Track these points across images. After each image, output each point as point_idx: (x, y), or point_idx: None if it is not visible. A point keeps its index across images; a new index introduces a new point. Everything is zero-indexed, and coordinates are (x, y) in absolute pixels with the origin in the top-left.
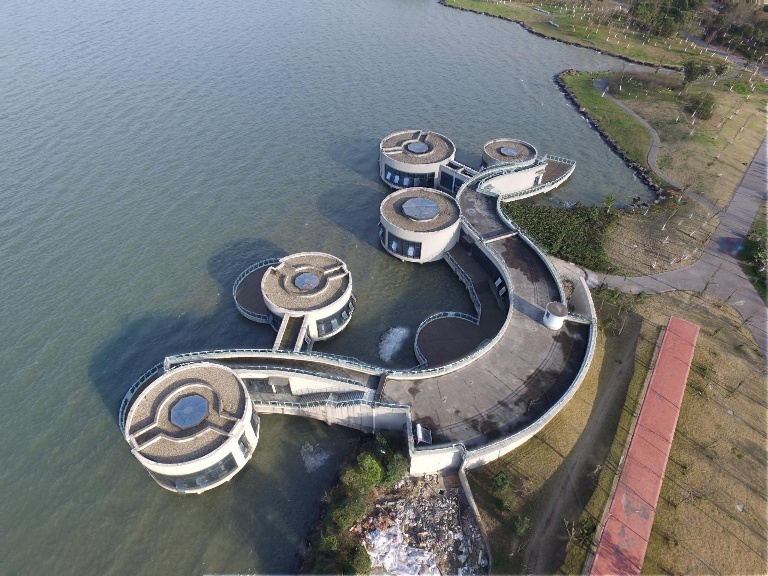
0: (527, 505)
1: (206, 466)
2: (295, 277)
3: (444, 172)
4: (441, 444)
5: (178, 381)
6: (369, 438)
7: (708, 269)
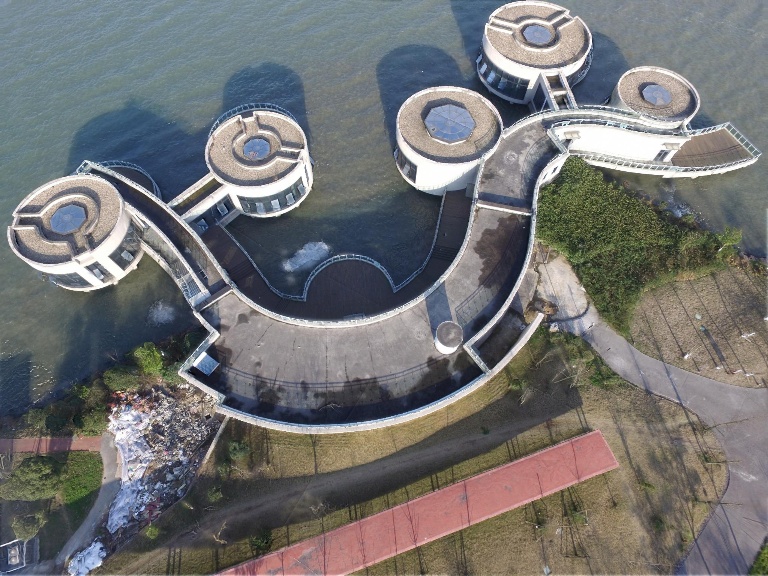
0: (246, 483)
1: (51, 272)
2: (253, 138)
3: (541, 85)
4: (216, 381)
5: (83, 187)
6: (206, 330)
7: (762, 408)
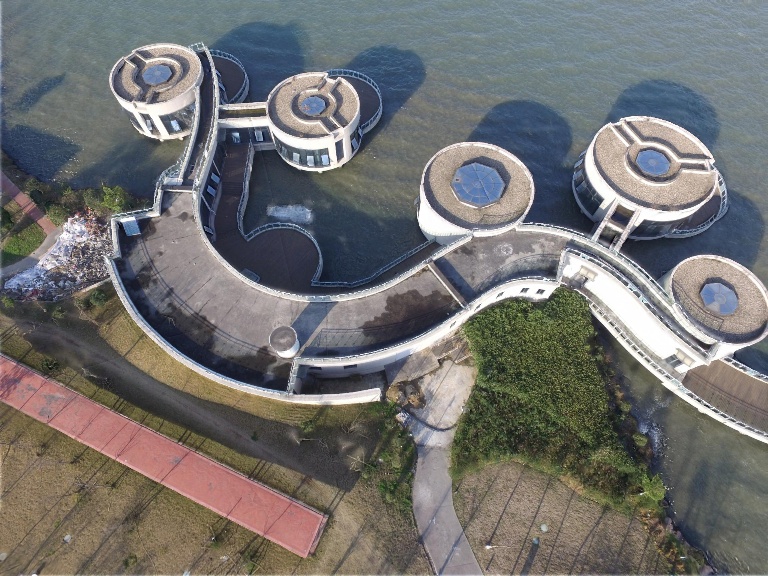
0: (86, 324)
1: None
2: (320, 97)
3: None
4: (127, 243)
5: (187, 60)
6: None
7: None
